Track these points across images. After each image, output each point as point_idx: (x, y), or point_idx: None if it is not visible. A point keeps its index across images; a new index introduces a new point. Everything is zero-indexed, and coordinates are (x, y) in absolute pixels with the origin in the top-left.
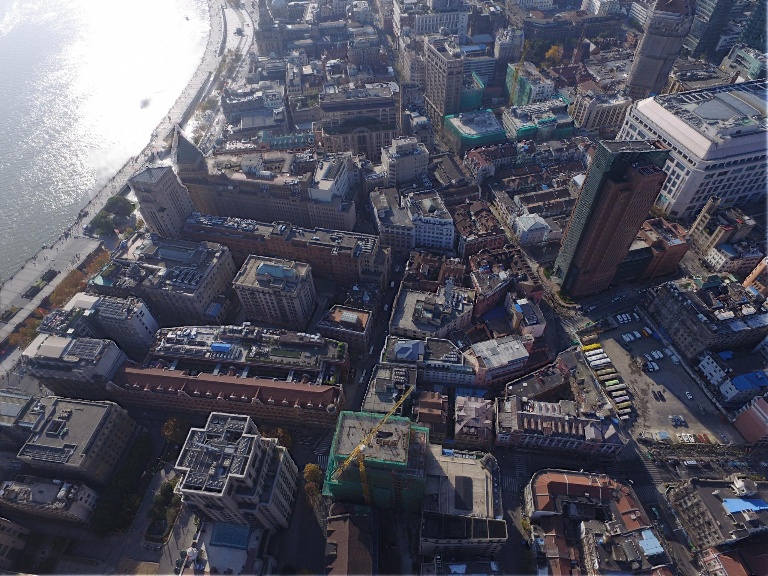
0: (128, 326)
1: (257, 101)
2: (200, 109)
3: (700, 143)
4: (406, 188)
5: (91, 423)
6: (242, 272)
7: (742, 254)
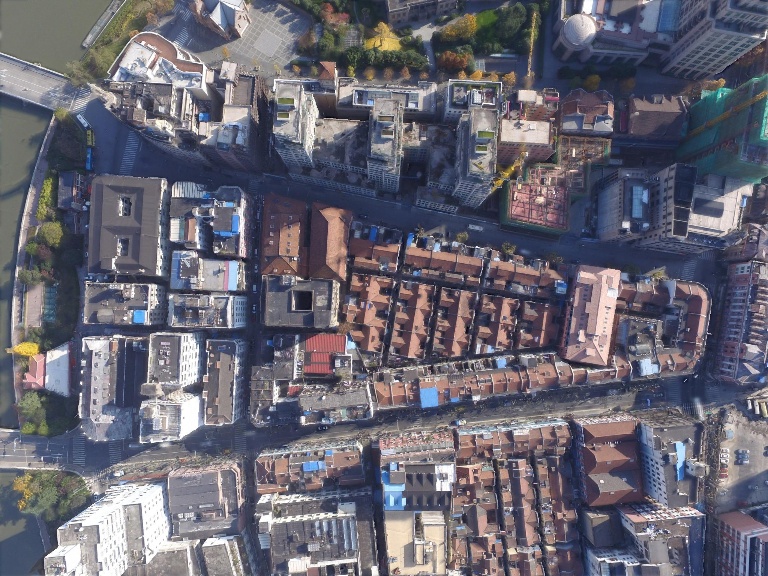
0: None
1: None
2: None
3: None
4: None
5: None
6: None
7: None
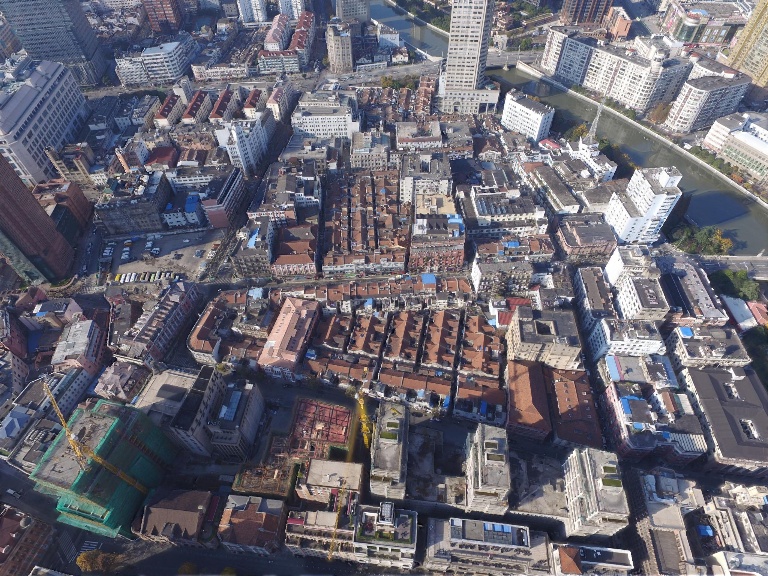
0: None
1: None
2: None
3: None
4: None
5: None
6: None
7: (106, 164)
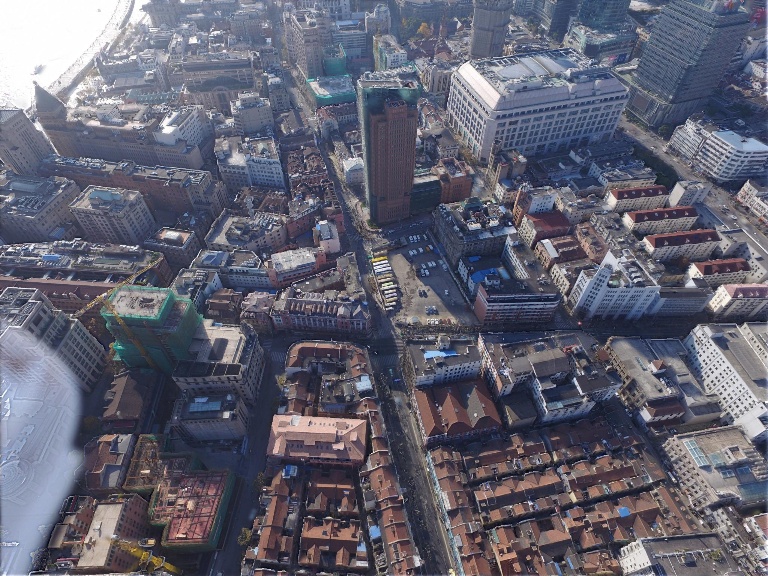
0: None
1: (132, 64)
2: (90, 75)
3: (493, 97)
4: (251, 137)
5: None
6: (79, 198)
7: (516, 186)
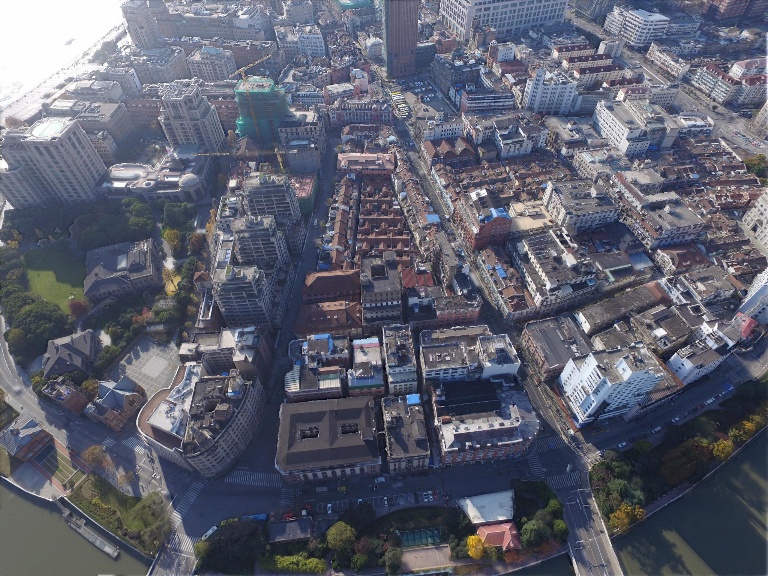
0: (126, 80)
1: None
2: None
3: None
4: None
5: (112, 108)
6: (192, 55)
7: None
